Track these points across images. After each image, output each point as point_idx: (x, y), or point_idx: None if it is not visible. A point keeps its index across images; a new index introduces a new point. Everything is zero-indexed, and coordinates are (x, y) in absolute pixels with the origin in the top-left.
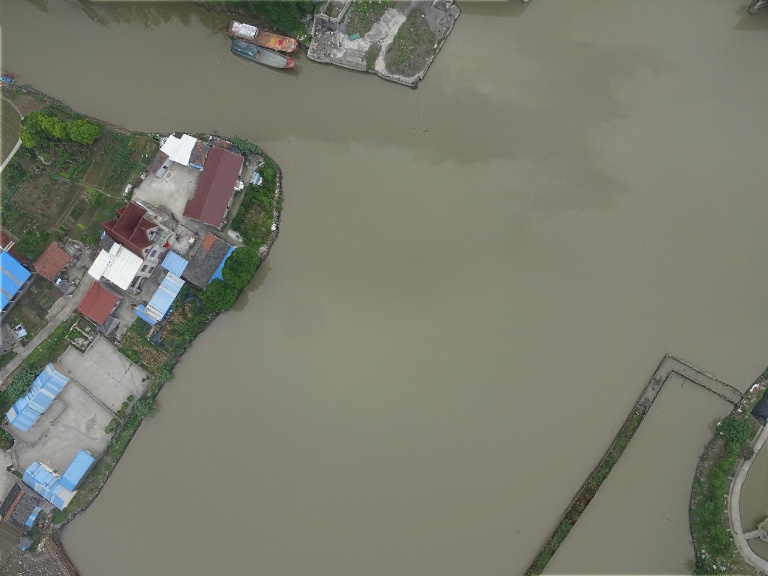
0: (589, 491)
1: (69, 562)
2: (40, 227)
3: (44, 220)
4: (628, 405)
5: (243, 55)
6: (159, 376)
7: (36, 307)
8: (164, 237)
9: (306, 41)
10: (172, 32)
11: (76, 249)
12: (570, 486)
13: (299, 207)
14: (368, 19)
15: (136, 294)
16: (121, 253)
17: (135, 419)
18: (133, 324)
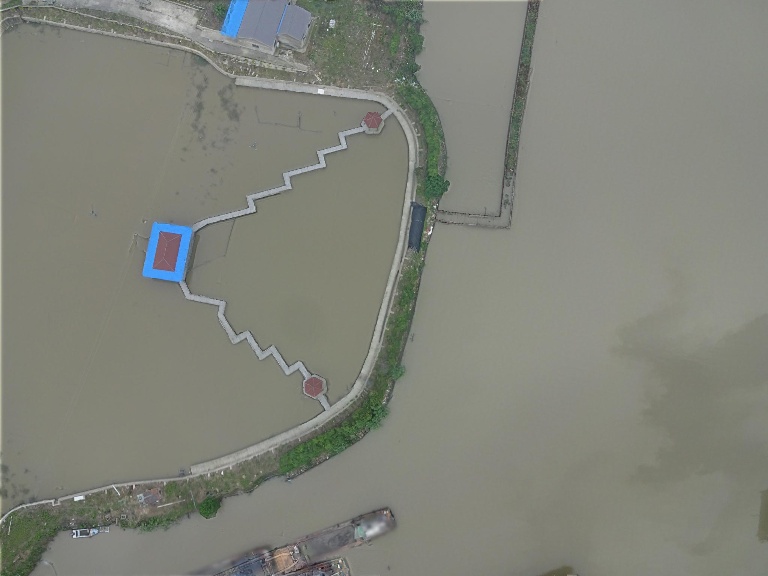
0: (522, 93)
1: None
2: None
3: None
4: None
5: None
6: None
7: None
8: None
9: None
10: None
11: None
12: None
13: None
14: None
15: None
16: None
17: None
18: None
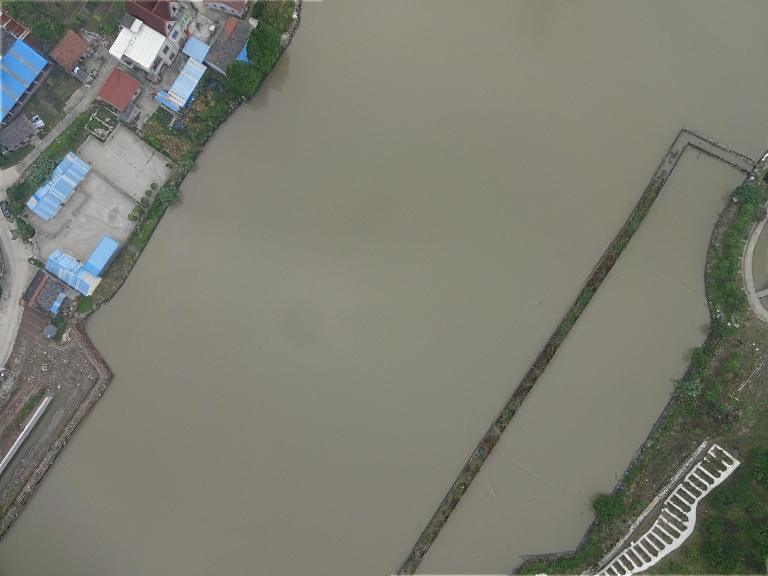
0: (610, 259)
1: (95, 350)
2: (54, 19)
3: (58, 13)
4: (646, 178)
5: None
6: (182, 164)
7: (53, 99)
8: (185, 19)
9: None
10: None
11: (93, 38)
12: (591, 258)
13: None
14: None
15: (157, 83)
16: (143, 31)
17: (159, 207)
18: (154, 113)
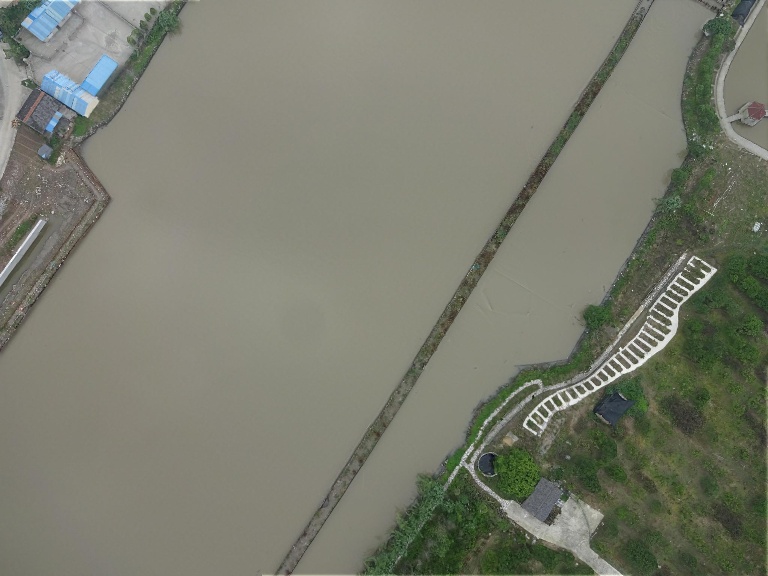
0: (595, 86)
1: (92, 173)
2: None
3: None
4: (627, 14)
5: None
6: None
7: None
8: None
9: None
10: None
11: None
12: None
13: None
14: None
15: None
16: None
17: (158, 33)
18: None
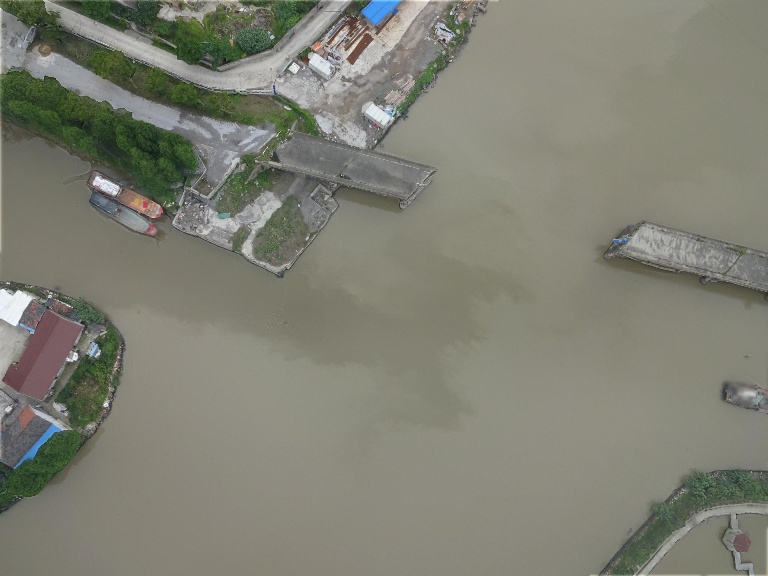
0: None
1: None
2: None
3: None
4: None
5: (102, 211)
6: None
7: None
8: None
9: (173, 209)
10: (34, 152)
11: None
12: None
13: (138, 385)
14: (241, 200)
15: None
16: None
17: None
18: None
